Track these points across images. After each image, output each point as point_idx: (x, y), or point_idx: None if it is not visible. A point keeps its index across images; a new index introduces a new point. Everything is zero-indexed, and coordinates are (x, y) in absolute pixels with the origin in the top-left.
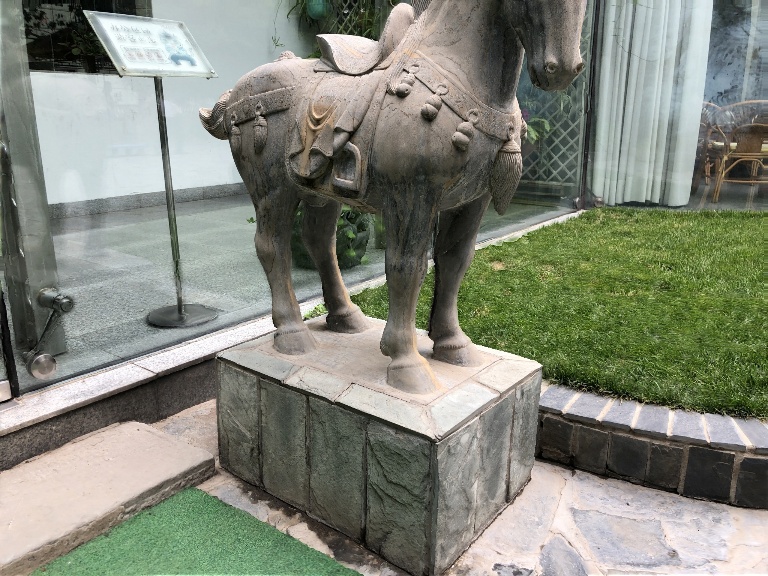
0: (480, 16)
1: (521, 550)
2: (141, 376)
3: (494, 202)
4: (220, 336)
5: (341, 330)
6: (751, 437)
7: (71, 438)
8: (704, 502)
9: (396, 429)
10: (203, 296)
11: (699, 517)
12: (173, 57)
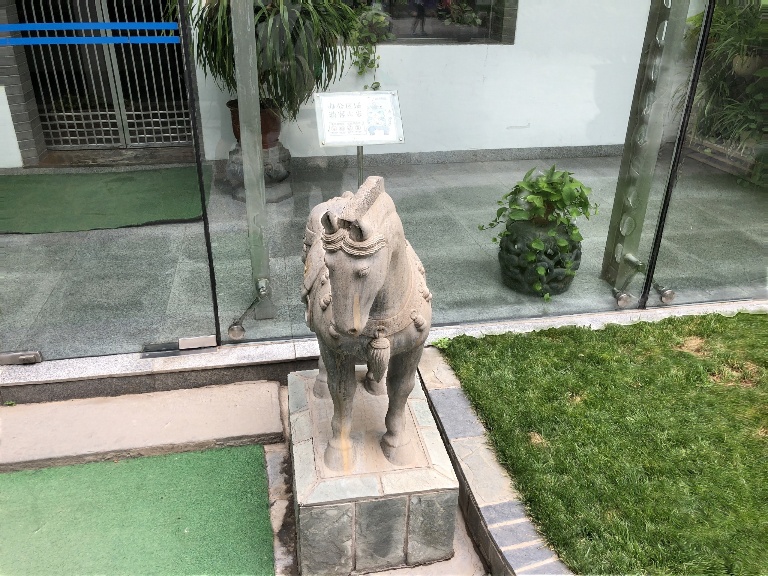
0: None
1: None
2: (287, 356)
3: None
4: None
5: (367, 388)
6: None
7: (236, 381)
8: None
9: None
10: None
11: None
12: (371, 128)
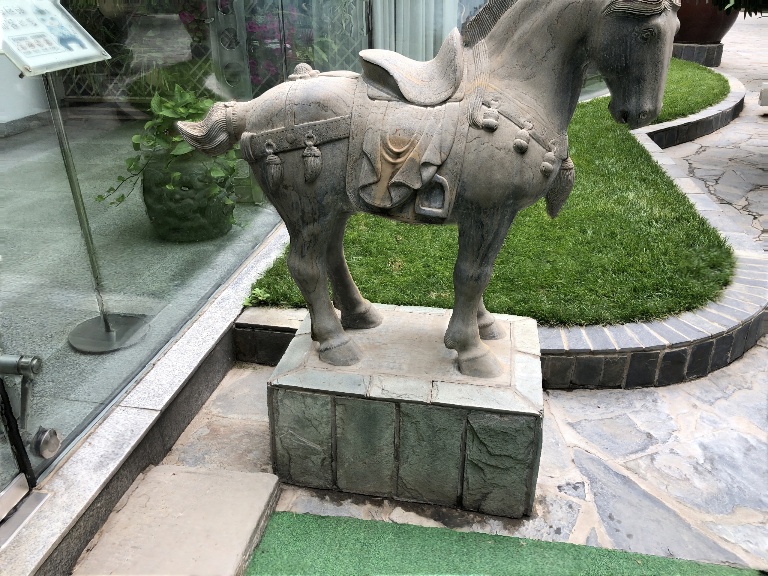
0: (555, 57)
1: (563, 469)
2: (146, 418)
3: (548, 209)
4: (178, 348)
5: (363, 326)
6: (665, 336)
7: (112, 507)
8: (640, 390)
9: (500, 413)
10: None
11: (645, 402)
12: (61, 41)
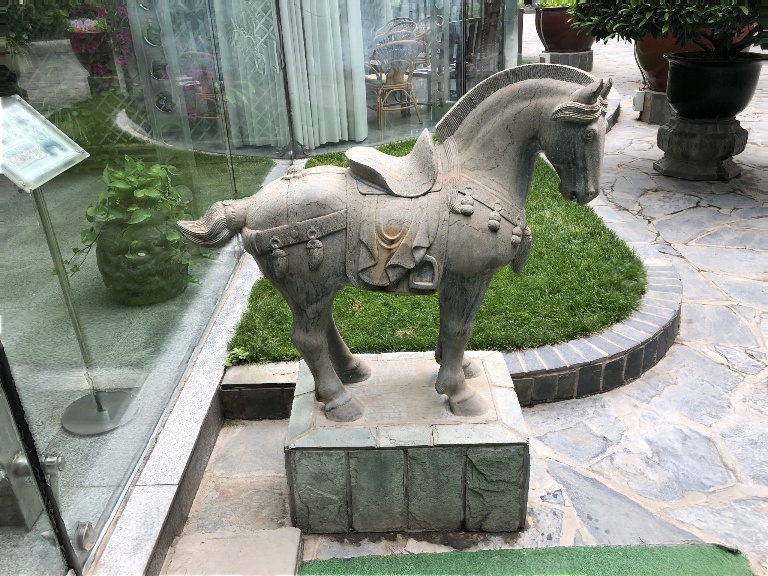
0: (515, 149)
1: (541, 480)
2: (167, 494)
3: (515, 268)
4: (174, 418)
5: (356, 380)
6: (604, 349)
7: None
8: (589, 398)
9: (494, 446)
10: (79, 379)
11: (595, 409)
12: (40, 147)
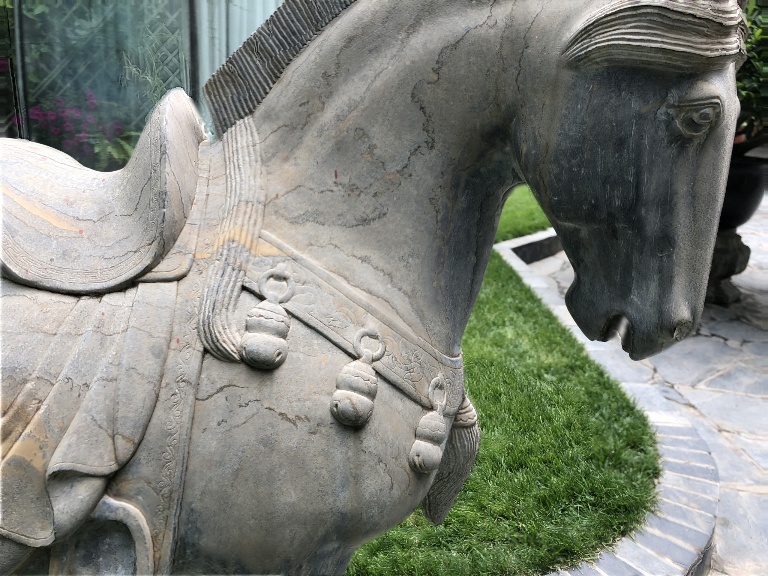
0: (435, 168)
1: None
2: None
3: (428, 509)
4: None
5: None
6: None
7: None
8: None
9: None
10: None
11: None
12: None
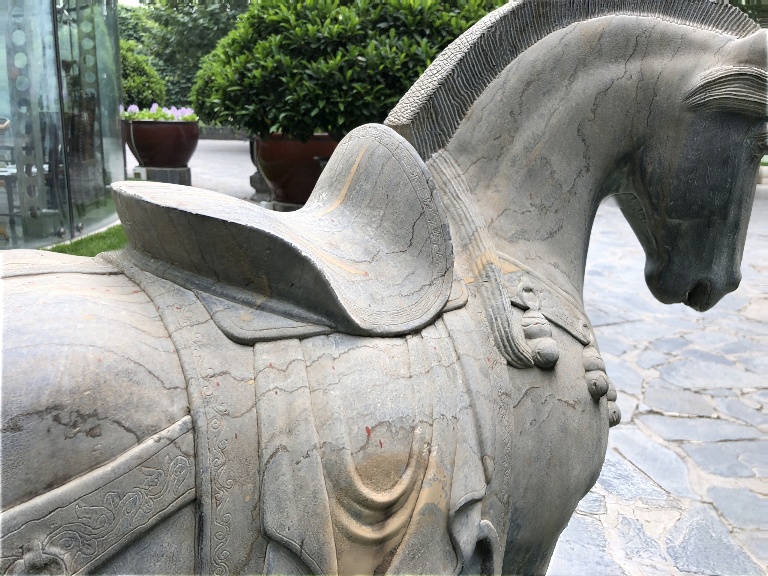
0: (589, 186)
1: None
2: None
3: None
4: None
5: None
6: None
7: None
8: None
9: None
10: None
11: None
12: None
